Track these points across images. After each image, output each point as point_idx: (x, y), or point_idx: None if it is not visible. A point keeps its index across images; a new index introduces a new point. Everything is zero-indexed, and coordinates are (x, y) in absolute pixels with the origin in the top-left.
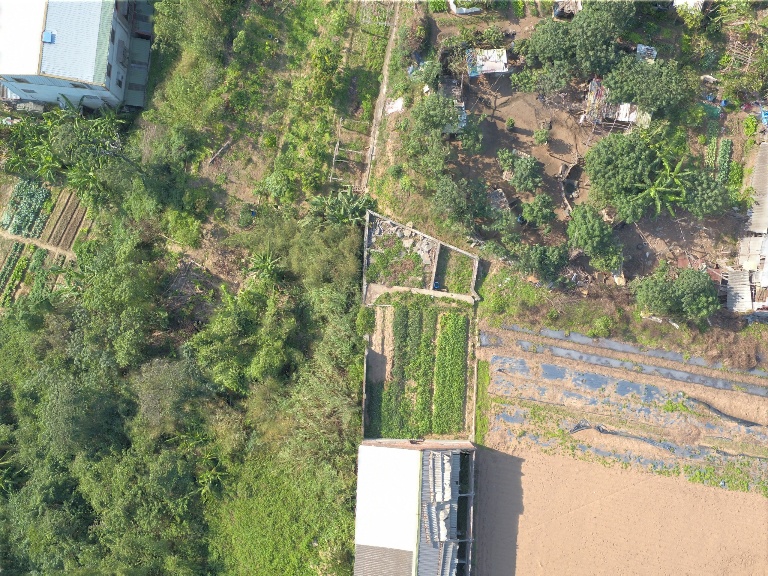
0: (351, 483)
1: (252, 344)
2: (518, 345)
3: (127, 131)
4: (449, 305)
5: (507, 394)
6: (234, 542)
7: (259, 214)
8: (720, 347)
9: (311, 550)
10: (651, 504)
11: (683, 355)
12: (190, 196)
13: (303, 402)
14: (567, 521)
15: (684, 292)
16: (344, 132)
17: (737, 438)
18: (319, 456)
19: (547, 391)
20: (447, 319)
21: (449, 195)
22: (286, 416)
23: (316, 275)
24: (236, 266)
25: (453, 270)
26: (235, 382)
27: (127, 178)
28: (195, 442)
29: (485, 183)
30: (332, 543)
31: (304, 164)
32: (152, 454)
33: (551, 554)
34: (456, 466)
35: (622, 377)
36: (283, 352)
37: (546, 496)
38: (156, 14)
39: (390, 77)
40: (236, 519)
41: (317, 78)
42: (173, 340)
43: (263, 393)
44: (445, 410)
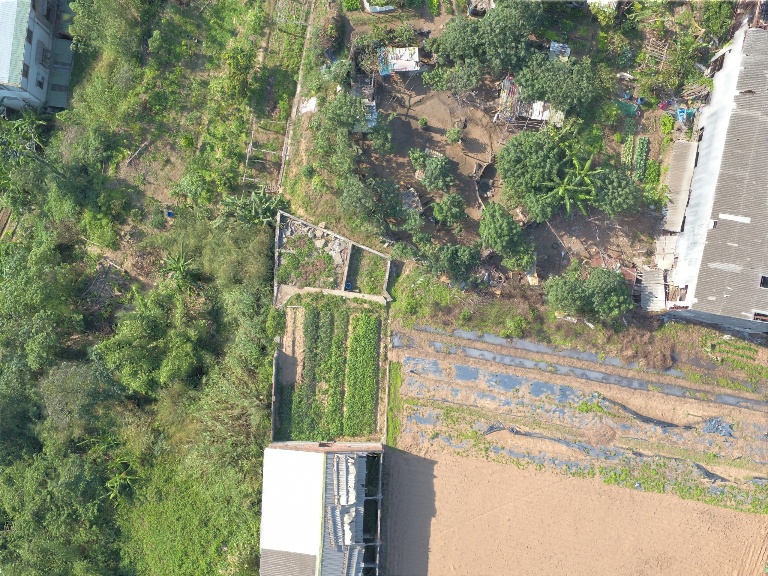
0: (257, 486)
1: (162, 346)
2: (431, 346)
3: (49, 132)
4: (361, 306)
5: (419, 395)
6: (145, 547)
7: (176, 215)
8: (635, 347)
9: (220, 554)
10: (565, 506)
11: (598, 355)
12: (105, 197)
13: (211, 405)
14: (480, 524)
15: (594, 291)
16: (261, 132)
17: (653, 439)
18: (226, 459)
19: (460, 392)
20: (359, 320)
21: (355, 195)
22: (193, 419)
23: (227, 276)
24: (155, 268)
25: (366, 271)
26: (144, 385)
27: (41, 179)
28: (106, 446)
29: (399, 183)
30: (241, 547)
31: (221, 164)
32: (62, 458)
33: (464, 557)
34: (362, 469)
35: (536, 378)
36: (193, 354)
37: (459, 498)
38: (76, 14)
39: (304, 76)
40: (146, 523)
41: (231, 78)
42: (91, 343)
43: (171, 396)
44: (356, 412)
